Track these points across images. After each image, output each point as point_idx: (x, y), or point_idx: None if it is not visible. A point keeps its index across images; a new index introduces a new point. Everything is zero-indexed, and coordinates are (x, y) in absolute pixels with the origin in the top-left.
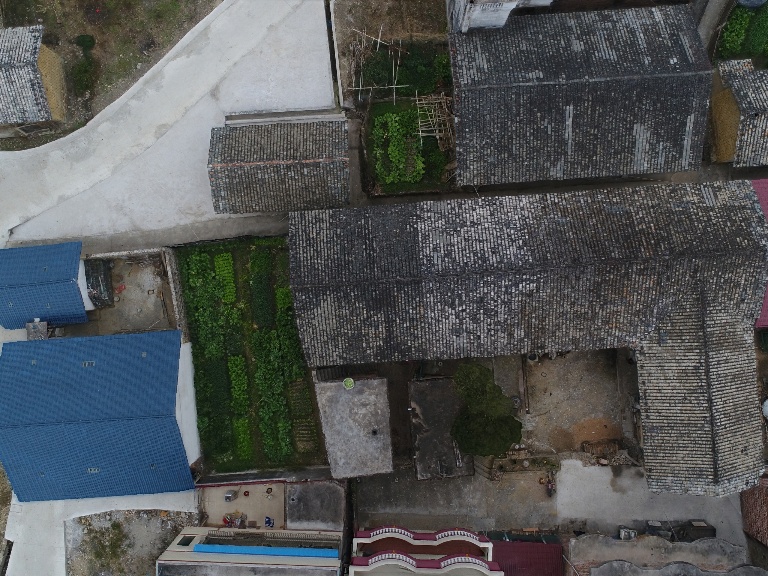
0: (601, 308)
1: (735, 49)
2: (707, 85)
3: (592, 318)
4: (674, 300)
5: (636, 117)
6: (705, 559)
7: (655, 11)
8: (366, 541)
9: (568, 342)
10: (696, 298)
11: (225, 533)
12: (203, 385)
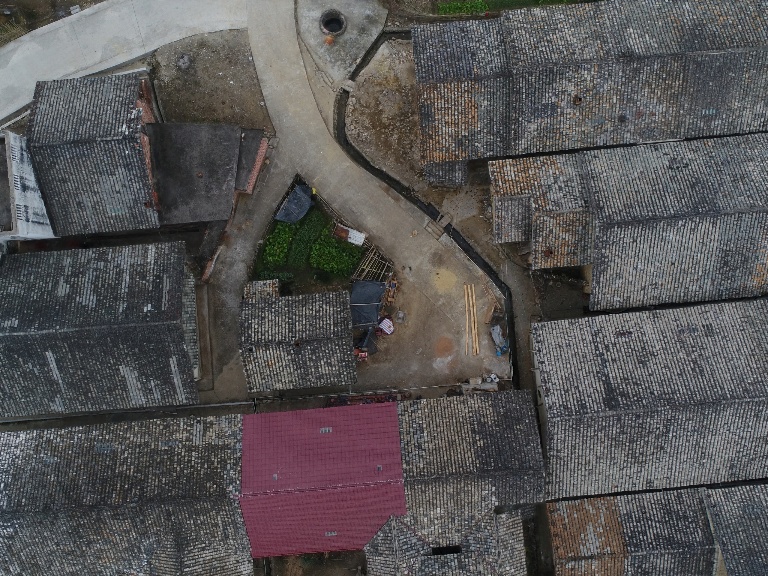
0: (87, 547)
1: (279, 262)
2: (178, 332)
3: (82, 555)
4: (157, 539)
5: (118, 360)
6: None
7: (151, 249)
8: None
9: (67, 574)
10: (174, 539)
11: None
12: None
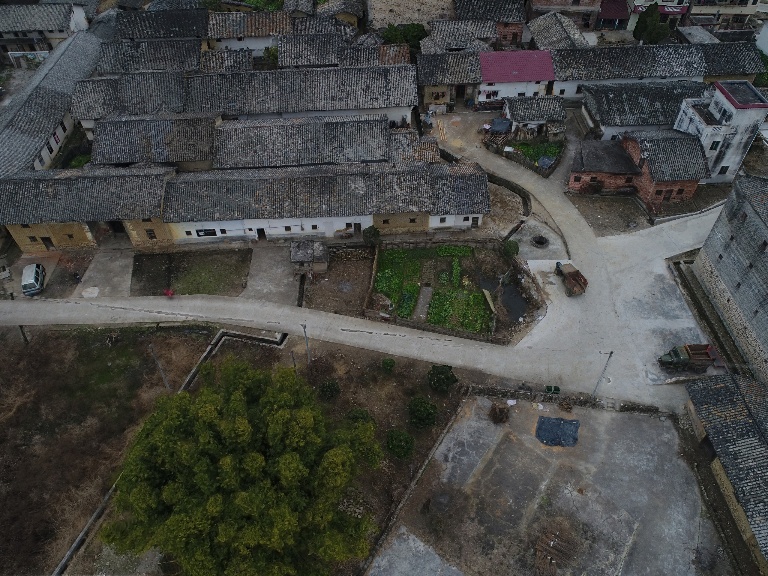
0: None
1: None
2: None
3: None
4: None
5: None
6: (548, 7)
7: (619, 123)
8: (684, 5)
9: None
10: None
11: (740, 7)
12: (767, 60)
